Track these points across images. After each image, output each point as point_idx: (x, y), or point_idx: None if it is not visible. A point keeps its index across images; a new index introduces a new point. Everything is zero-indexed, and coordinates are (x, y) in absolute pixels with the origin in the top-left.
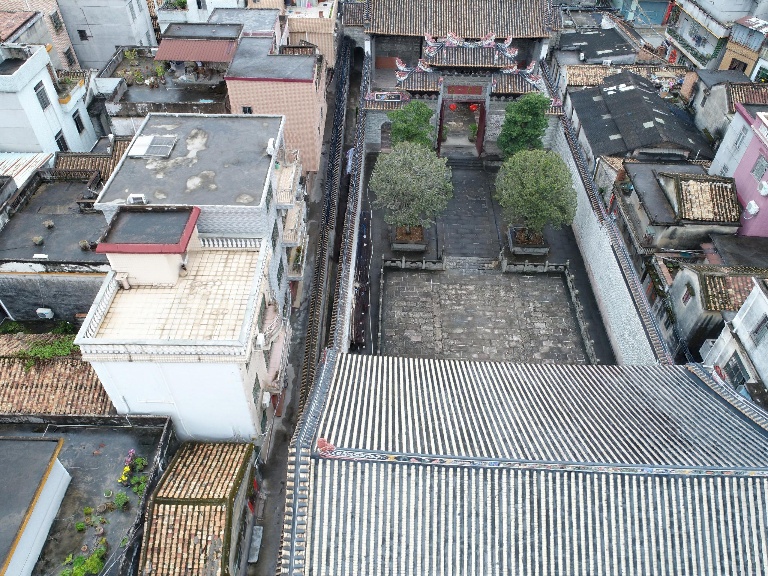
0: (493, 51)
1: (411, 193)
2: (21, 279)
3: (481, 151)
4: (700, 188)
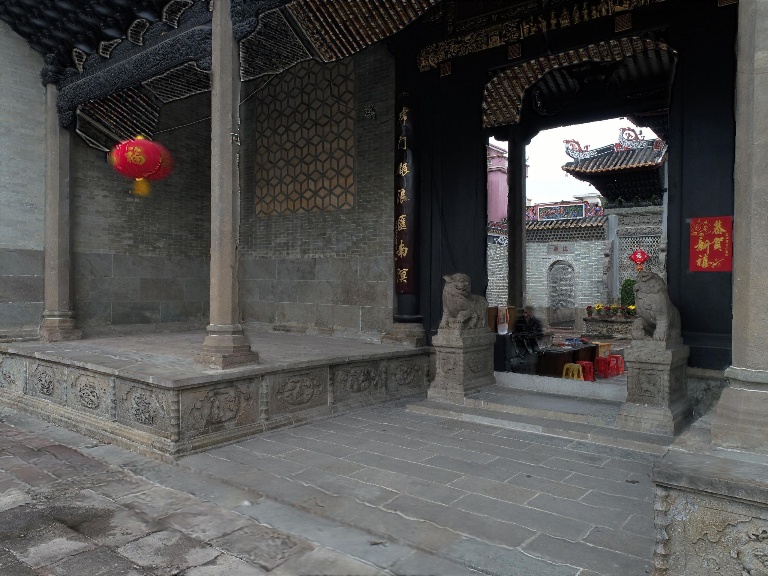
0: None
1: None
2: None
3: None
4: None
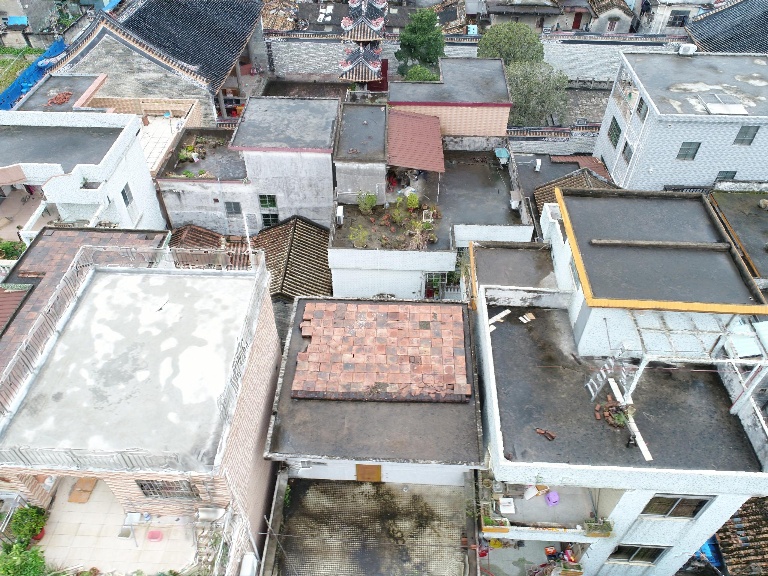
0: (371, 4)
1: None
2: None
3: None
4: None
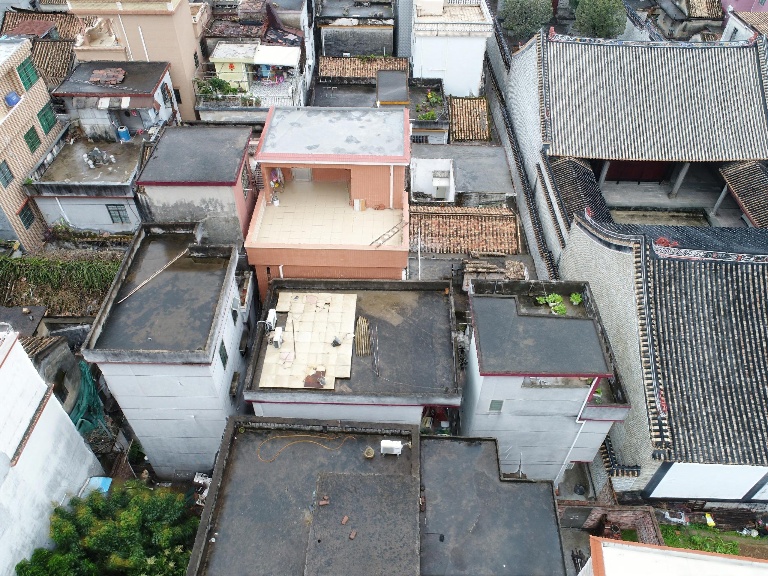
0: None
1: (530, 11)
2: (341, 32)
3: (555, 13)
4: (700, 1)
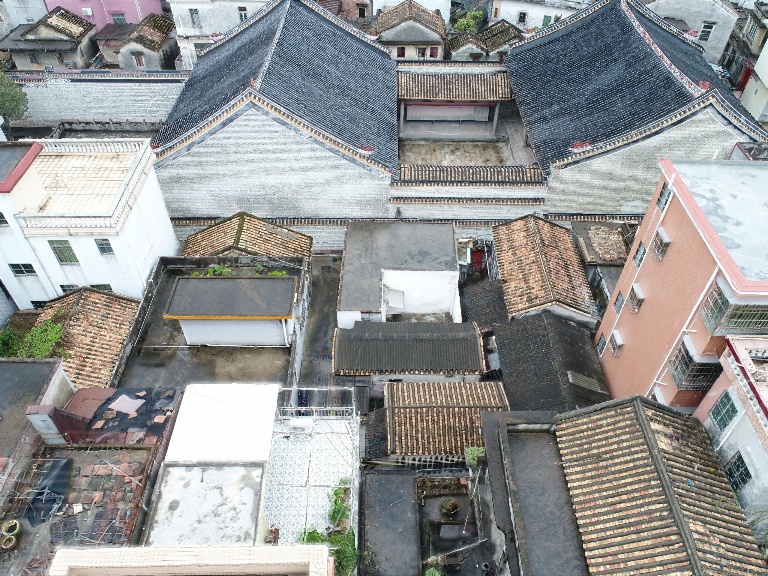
0: None
1: None
2: None
3: None
4: (57, 20)
